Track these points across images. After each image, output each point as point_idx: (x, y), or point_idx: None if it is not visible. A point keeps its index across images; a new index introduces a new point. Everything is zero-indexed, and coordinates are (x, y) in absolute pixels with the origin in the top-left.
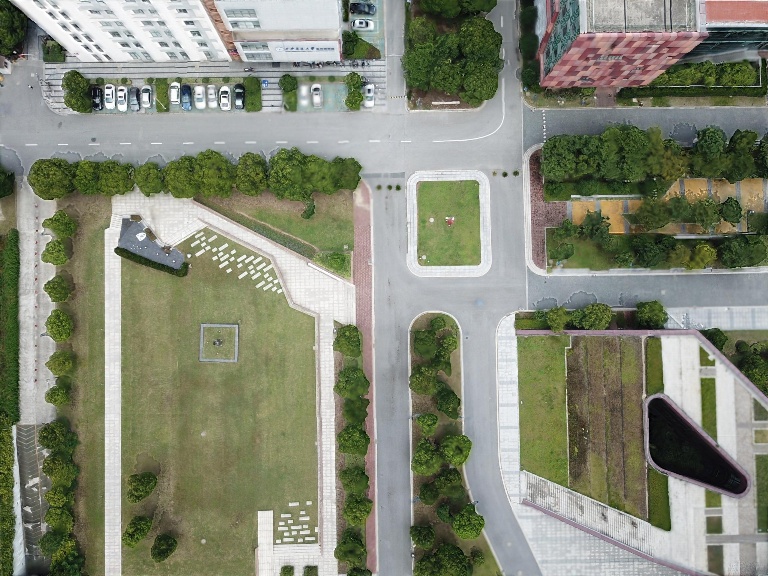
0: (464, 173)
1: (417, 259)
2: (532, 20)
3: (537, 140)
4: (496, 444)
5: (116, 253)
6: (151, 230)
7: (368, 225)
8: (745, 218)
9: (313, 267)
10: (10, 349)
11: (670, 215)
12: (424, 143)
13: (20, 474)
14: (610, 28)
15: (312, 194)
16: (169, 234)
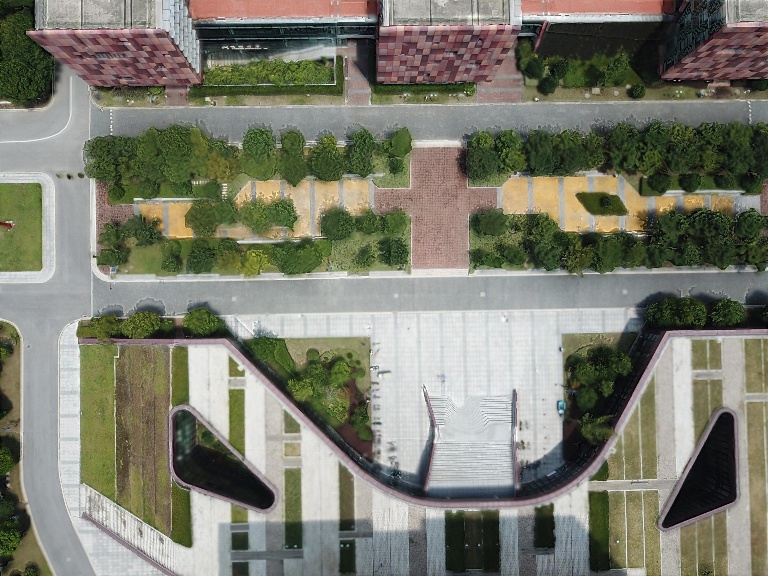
0: (27, 175)
1: None
2: None
3: None
4: (56, 456)
5: None
6: None
7: None
8: (319, 222)
9: None
10: None
11: (215, 219)
12: None
13: None
14: (65, 25)
15: None
16: None
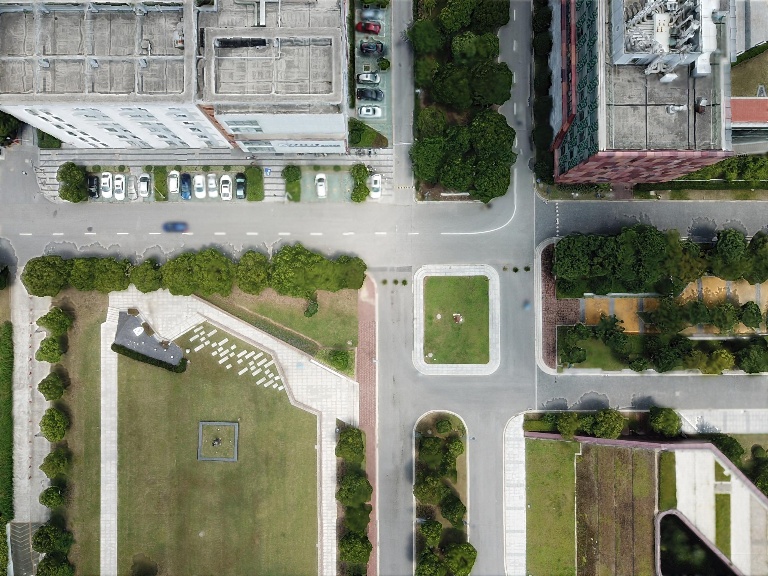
0: (473, 268)
1: (423, 357)
2: (547, 111)
3: (549, 234)
4: (502, 548)
5: (112, 350)
6: (149, 324)
7: (373, 321)
8: (764, 318)
9: (316, 364)
10: (4, 447)
11: (687, 320)
12: (432, 236)
13: (14, 572)
14: (630, 145)
15: None
16: (167, 328)
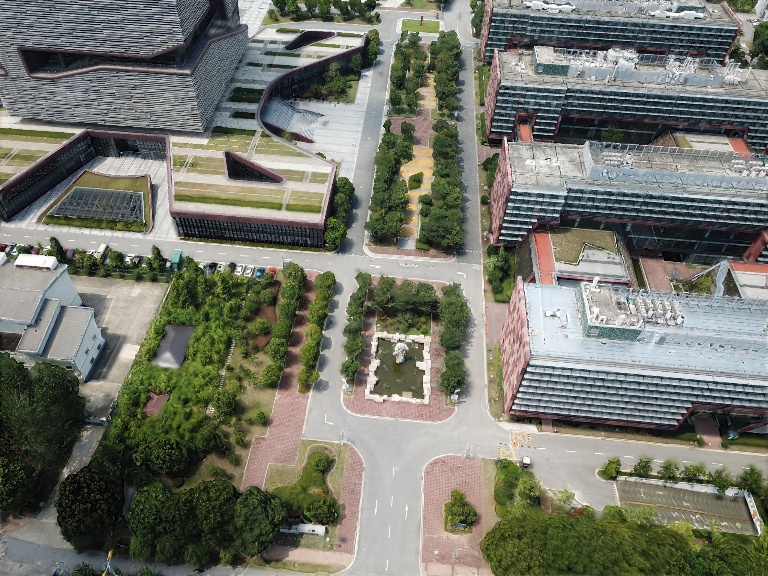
0: None
1: None
2: None
3: None
4: None
5: None
6: None
7: None
8: None
9: None
10: None
11: None
12: None
13: None
14: None
15: (436, 3)
16: None
